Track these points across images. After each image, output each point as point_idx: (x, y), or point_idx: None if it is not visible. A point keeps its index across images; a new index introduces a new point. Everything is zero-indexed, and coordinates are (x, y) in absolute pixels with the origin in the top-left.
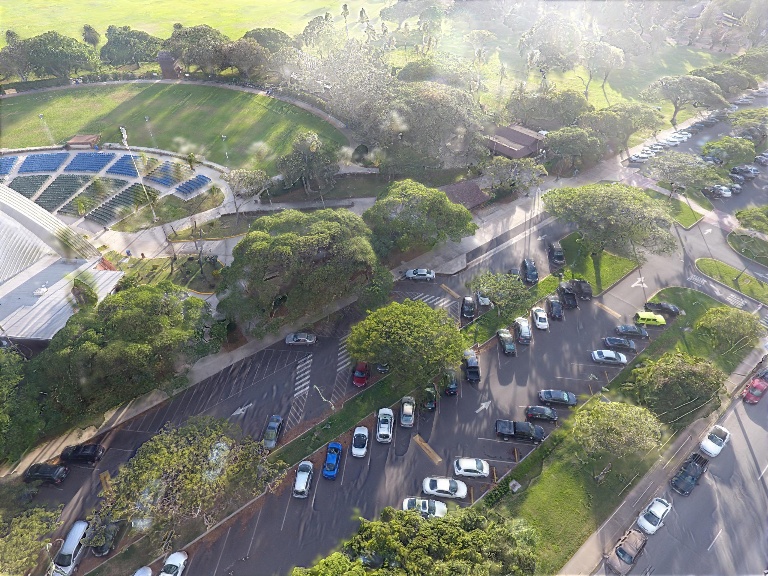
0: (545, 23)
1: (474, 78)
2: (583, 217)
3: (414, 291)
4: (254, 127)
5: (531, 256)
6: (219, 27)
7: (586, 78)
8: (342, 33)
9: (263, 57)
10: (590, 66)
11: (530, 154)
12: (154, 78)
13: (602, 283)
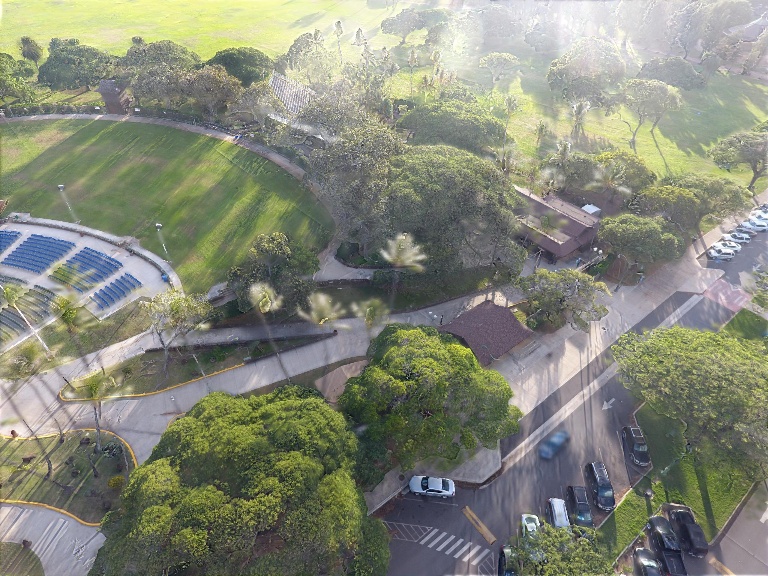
0: (582, 51)
1: (499, 130)
2: (691, 416)
3: (422, 523)
4: (212, 193)
5: (597, 445)
6: (195, 36)
7: (629, 119)
8: (334, 56)
9: (231, 92)
10: (640, 110)
11: (578, 248)
12: (96, 112)
13: (714, 513)
